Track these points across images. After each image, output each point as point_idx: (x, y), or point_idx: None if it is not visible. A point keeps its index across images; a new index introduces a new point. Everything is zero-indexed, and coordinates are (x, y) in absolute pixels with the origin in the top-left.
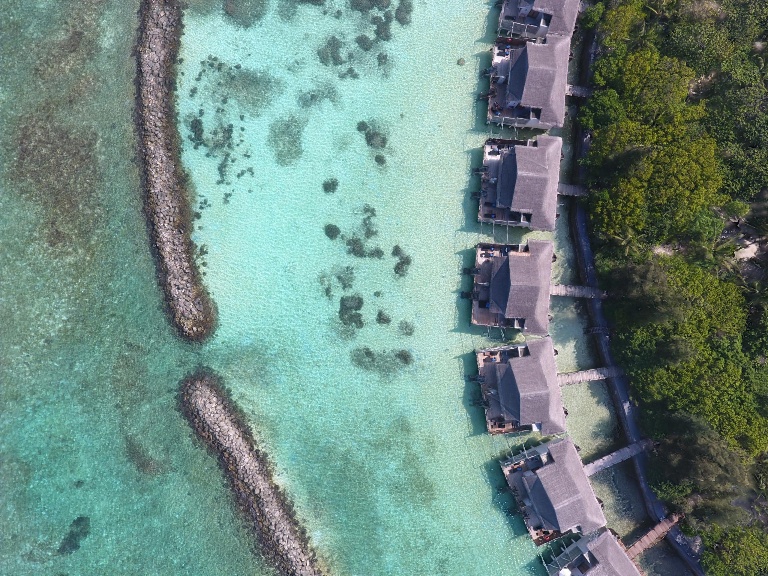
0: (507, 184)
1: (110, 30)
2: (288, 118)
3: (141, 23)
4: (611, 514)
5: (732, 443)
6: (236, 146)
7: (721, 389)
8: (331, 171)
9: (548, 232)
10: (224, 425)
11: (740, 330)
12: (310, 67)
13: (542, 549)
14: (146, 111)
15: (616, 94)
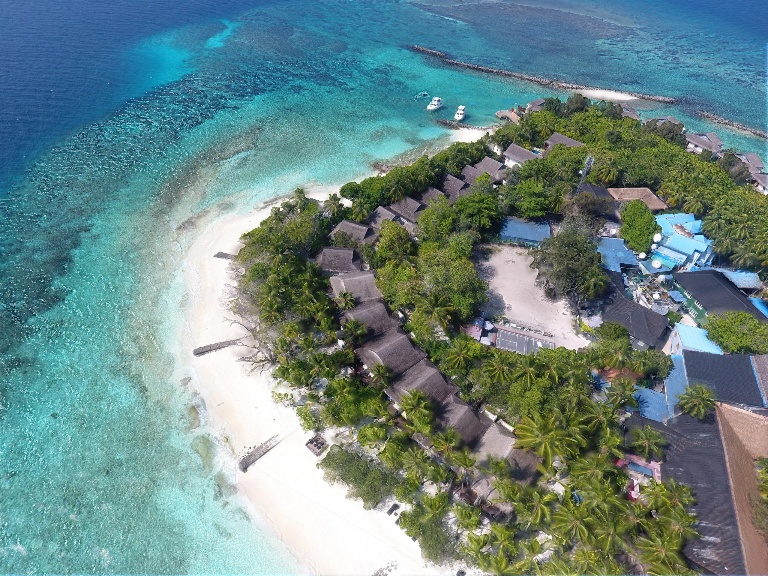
0: None
1: None
2: None
3: None
4: None
5: (660, 138)
6: None
7: None
8: None
9: None
10: None
11: None
12: None
13: None
14: None
15: None
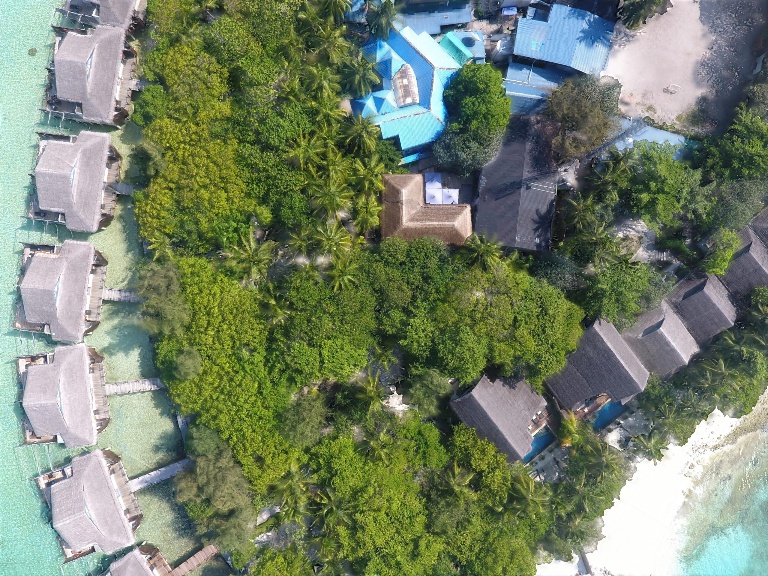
0: None
1: None
2: None
3: None
4: (169, 532)
5: (245, 462)
6: None
7: (237, 404)
8: None
9: (117, 233)
10: None
11: (262, 342)
12: None
13: (92, 567)
14: None
15: (161, 90)
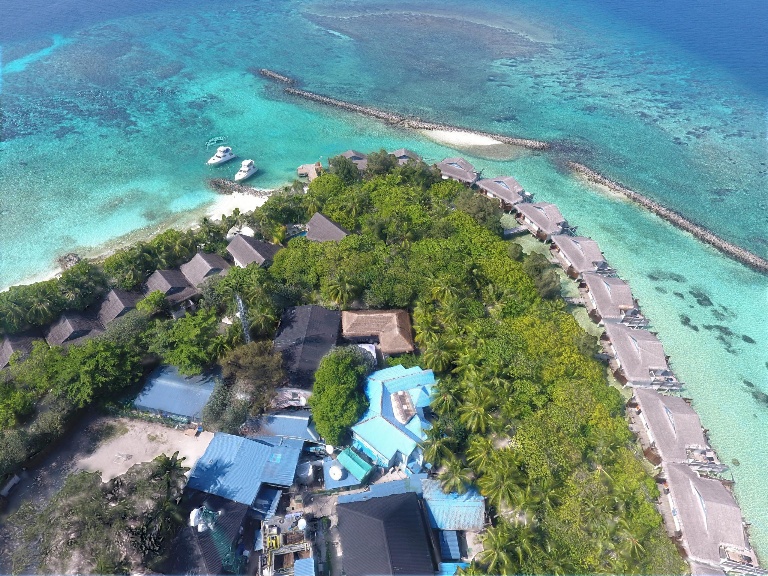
0: None
1: None
2: None
3: None
4: None
5: (469, 218)
6: None
7: None
8: None
9: None
10: (738, 251)
11: None
12: None
13: None
14: None
15: (605, 405)
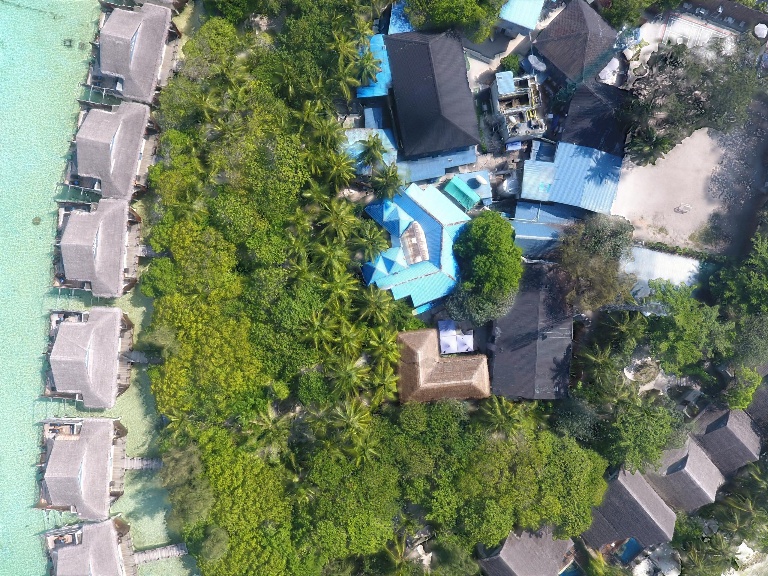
0: None
1: None
2: None
3: None
4: None
5: None
6: None
7: None
8: None
9: (134, 398)
10: None
11: (288, 517)
12: None
13: None
14: None
15: (169, 263)
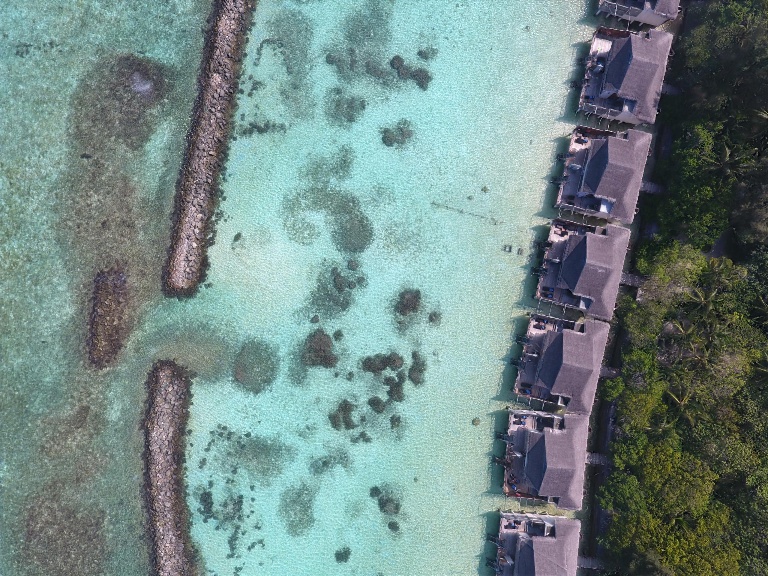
0: (524, 575)
1: (117, 402)
2: (299, 486)
3: (149, 395)
4: None
5: None
6: (246, 518)
7: None
8: (343, 540)
9: None
10: None
11: None
12: (321, 432)
13: None
14: (154, 490)
15: (636, 482)
